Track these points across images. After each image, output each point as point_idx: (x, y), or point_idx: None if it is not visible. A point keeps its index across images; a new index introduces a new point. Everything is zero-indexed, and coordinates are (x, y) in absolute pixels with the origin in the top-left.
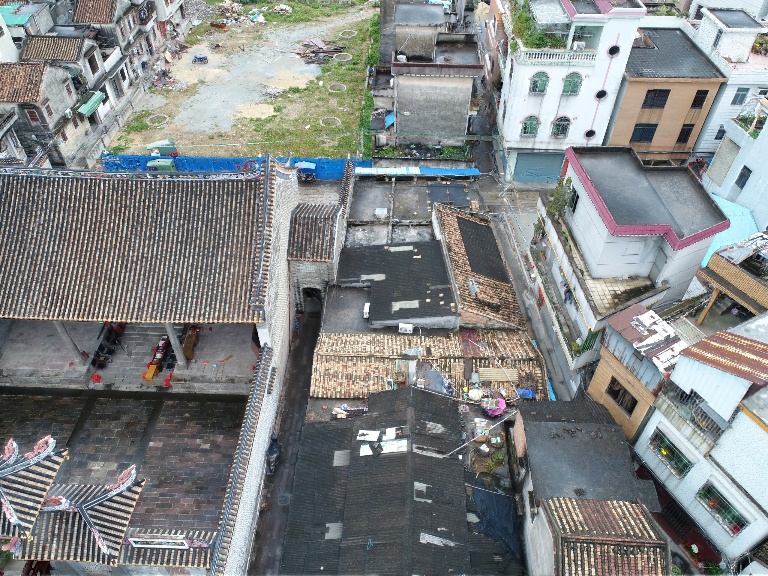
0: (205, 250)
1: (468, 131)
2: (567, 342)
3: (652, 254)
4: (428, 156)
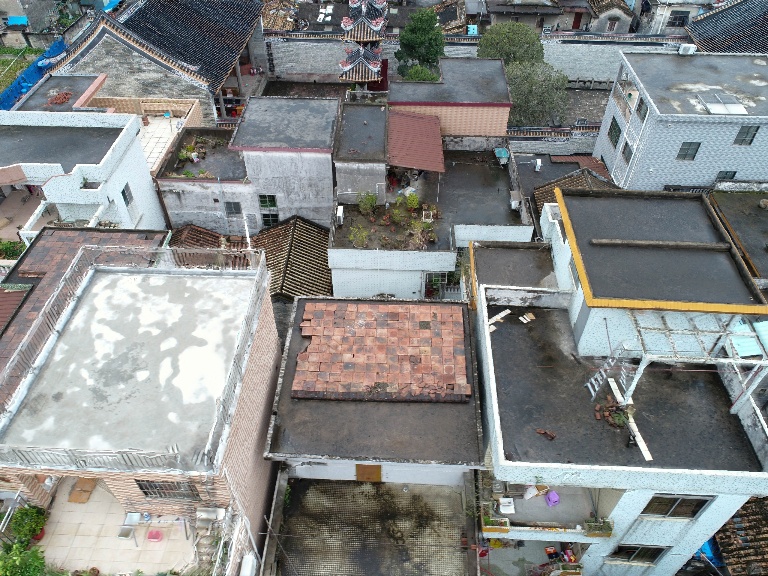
0: None
1: (55, 3)
2: None
3: None
4: (63, 28)
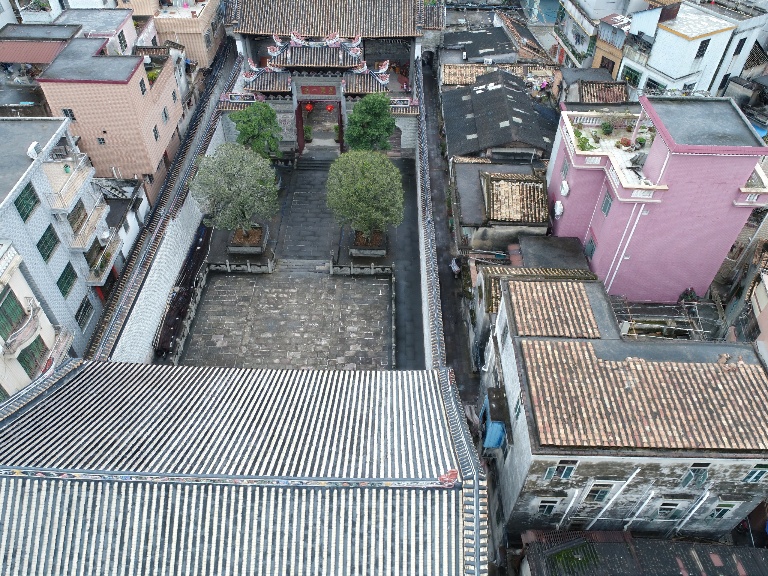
0: (387, 4)
1: None
2: (578, 58)
3: (622, 3)
4: None
